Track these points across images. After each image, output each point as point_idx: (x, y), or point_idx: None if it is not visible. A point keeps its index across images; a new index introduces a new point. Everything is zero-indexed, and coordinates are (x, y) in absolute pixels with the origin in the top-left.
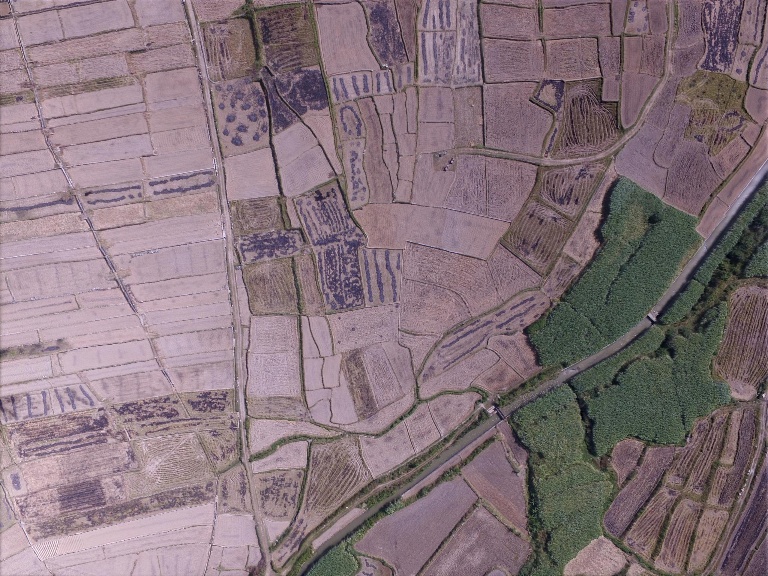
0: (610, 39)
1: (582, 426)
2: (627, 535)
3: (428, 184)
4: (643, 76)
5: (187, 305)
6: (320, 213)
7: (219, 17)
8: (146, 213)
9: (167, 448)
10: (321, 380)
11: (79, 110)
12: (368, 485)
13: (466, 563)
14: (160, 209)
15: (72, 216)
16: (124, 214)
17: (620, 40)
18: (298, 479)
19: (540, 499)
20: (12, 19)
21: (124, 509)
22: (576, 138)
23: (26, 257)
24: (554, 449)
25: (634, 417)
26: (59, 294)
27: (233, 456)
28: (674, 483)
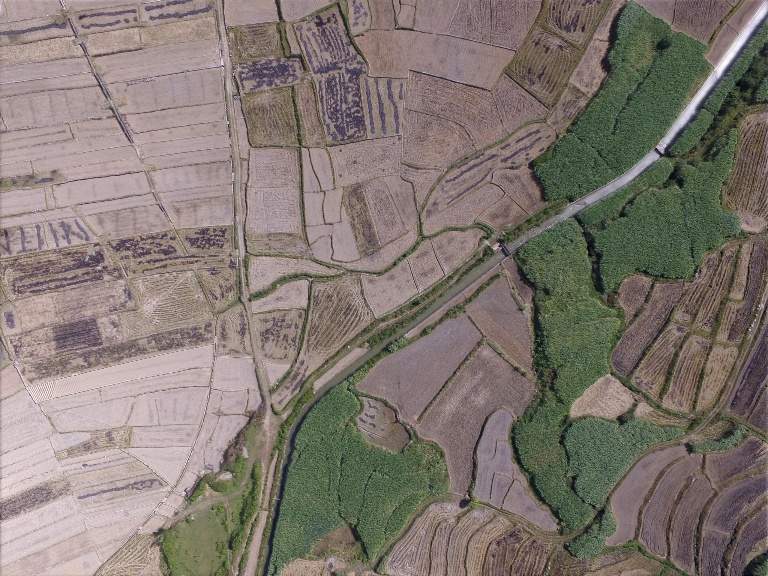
0: None
1: (589, 261)
2: (635, 373)
3: (431, 10)
4: None
5: (184, 137)
6: (321, 39)
7: None
8: (142, 39)
9: (165, 287)
10: (322, 215)
11: None
12: (370, 324)
13: (470, 403)
14: (156, 35)
15: (66, 41)
16: (119, 39)
17: None
18: (299, 320)
19: (546, 336)
20: None
21: (121, 350)
22: None
23: (19, 84)
24: (560, 284)
25: (642, 249)
26: (53, 123)
27: (232, 296)
28: (682, 320)
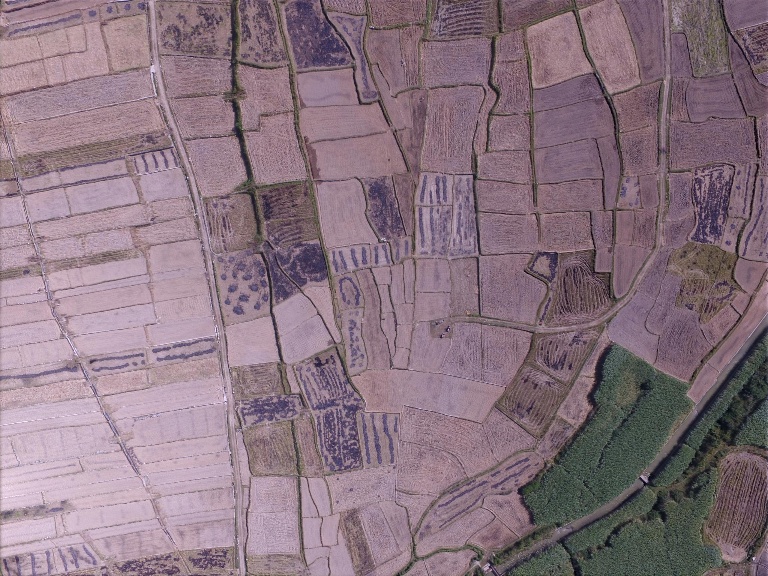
0: (603, 213)
1: None
2: None
3: (425, 351)
4: (635, 248)
5: (189, 466)
6: (319, 379)
7: (222, 192)
8: (149, 379)
9: None
10: (320, 539)
11: (85, 282)
12: None
13: None
14: (163, 375)
15: (77, 383)
16: (128, 380)
17: (612, 214)
18: None
19: None
20: (20, 197)
21: None
22: (570, 307)
23: (31, 422)
24: None
25: None
26: (63, 457)
27: None
28: None
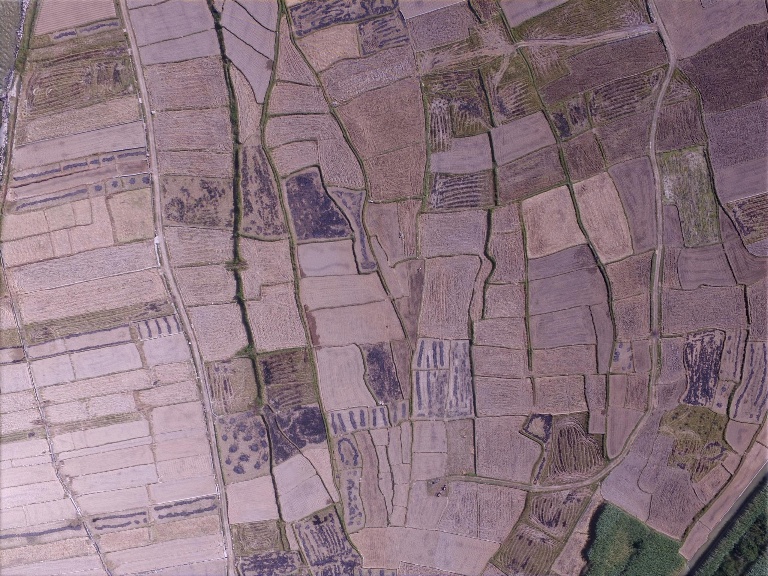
0: (596, 377)
1: None
2: None
3: (422, 508)
4: (628, 410)
5: None
6: (318, 536)
7: (223, 357)
8: (151, 536)
9: None
10: None
11: (88, 444)
12: None
13: None
14: (164, 532)
15: (80, 540)
16: (130, 538)
17: (606, 378)
18: None
19: None
20: (26, 363)
21: None
22: (564, 466)
23: None
24: None
25: None
26: None
27: None
28: None
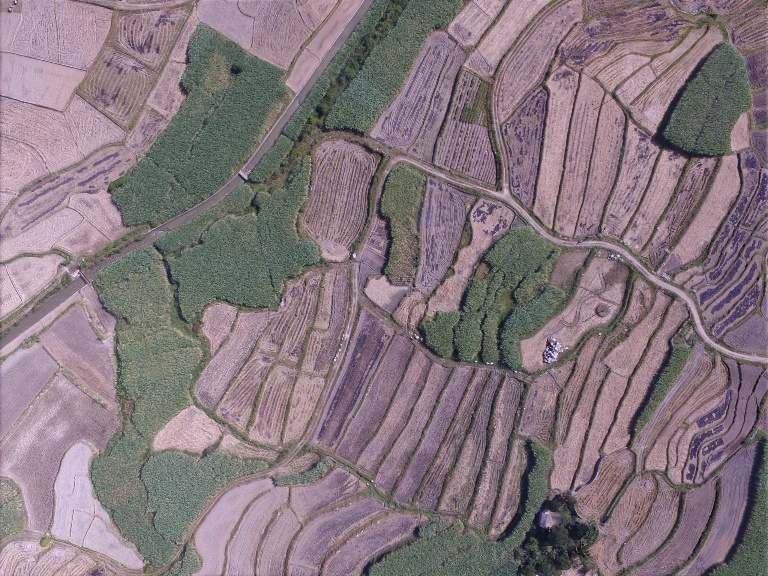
0: None
1: (169, 289)
2: (220, 405)
3: None
4: None
5: None
6: None
7: None
8: None
9: None
10: None
11: None
12: None
13: (48, 437)
14: None
15: None
16: None
17: None
18: None
19: (124, 367)
20: None
21: None
22: None
23: None
24: (138, 313)
25: (219, 278)
26: None
27: None
28: (269, 350)
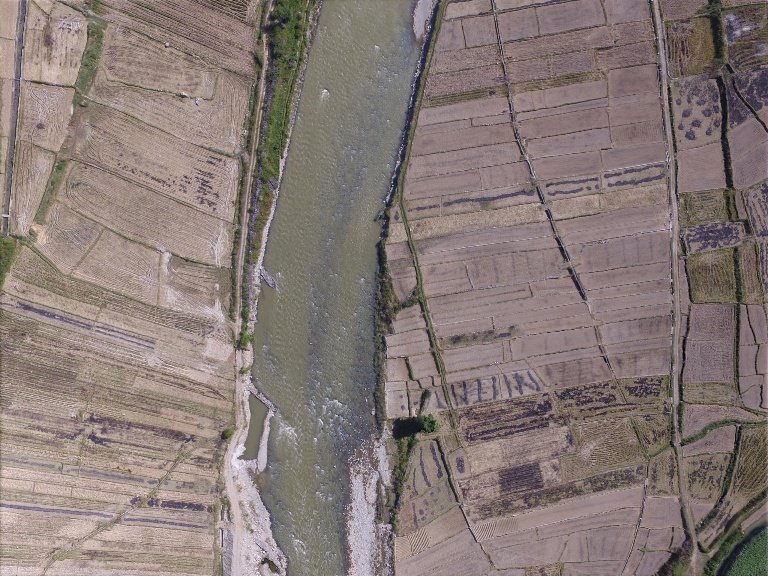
0: None
1: None
2: None
3: None
4: None
5: (631, 293)
6: (765, 205)
7: (683, 16)
8: (600, 204)
9: (602, 432)
10: (754, 366)
11: (547, 104)
12: None
13: None
14: (613, 200)
15: (532, 207)
16: (581, 205)
17: None
18: (724, 462)
19: None
20: (492, 16)
21: (559, 492)
22: None
23: (486, 246)
24: None
25: None
26: (514, 282)
27: (664, 440)
28: None
